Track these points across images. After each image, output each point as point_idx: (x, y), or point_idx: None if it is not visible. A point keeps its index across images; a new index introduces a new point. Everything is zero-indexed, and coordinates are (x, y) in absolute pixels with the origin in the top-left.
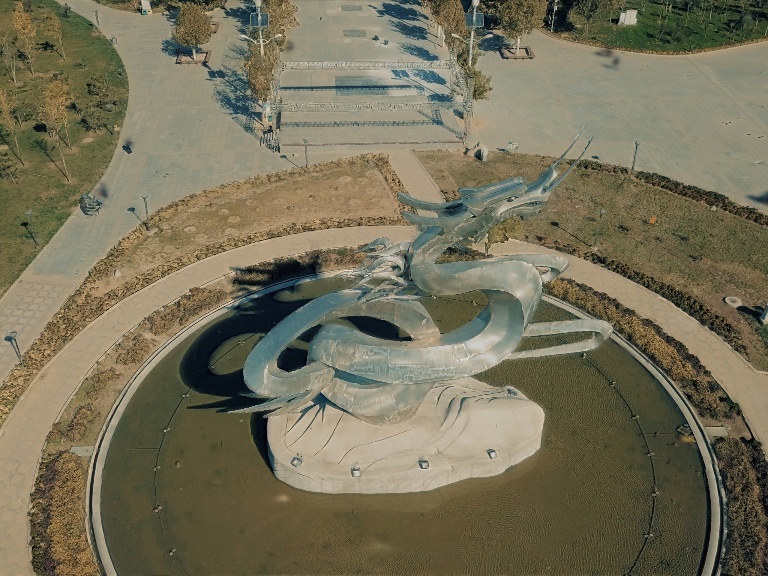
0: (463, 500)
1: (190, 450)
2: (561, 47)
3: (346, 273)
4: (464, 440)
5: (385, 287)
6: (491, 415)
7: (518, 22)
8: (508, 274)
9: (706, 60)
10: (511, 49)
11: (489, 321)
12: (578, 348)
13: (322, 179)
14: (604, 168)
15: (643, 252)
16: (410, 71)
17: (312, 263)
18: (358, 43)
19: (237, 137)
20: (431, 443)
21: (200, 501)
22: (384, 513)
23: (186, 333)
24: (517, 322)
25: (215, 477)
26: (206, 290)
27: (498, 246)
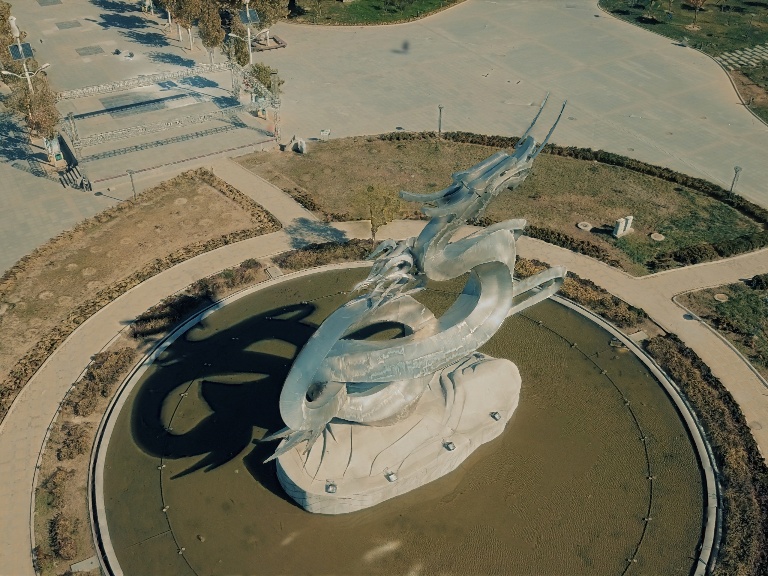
0: (473, 469)
1: (203, 520)
2: (304, 31)
3: (362, 284)
4: (468, 412)
5: (392, 288)
6: (482, 381)
7: (267, 13)
8: (496, 244)
9: (435, 23)
10: (260, 41)
11: (480, 293)
12: (542, 297)
13: (157, 207)
14: (413, 136)
15: (491, 203)
16: (174, 80)
17: (206, 294)
18: (100, 60)
19: (32, 185)
20: (444, 425)
21: (248, 565)
22: (419, 507)
23: (119, 404)
24: (506, 287)
25: (248, 536)
26: (110, 353)
27: (369, 230)
